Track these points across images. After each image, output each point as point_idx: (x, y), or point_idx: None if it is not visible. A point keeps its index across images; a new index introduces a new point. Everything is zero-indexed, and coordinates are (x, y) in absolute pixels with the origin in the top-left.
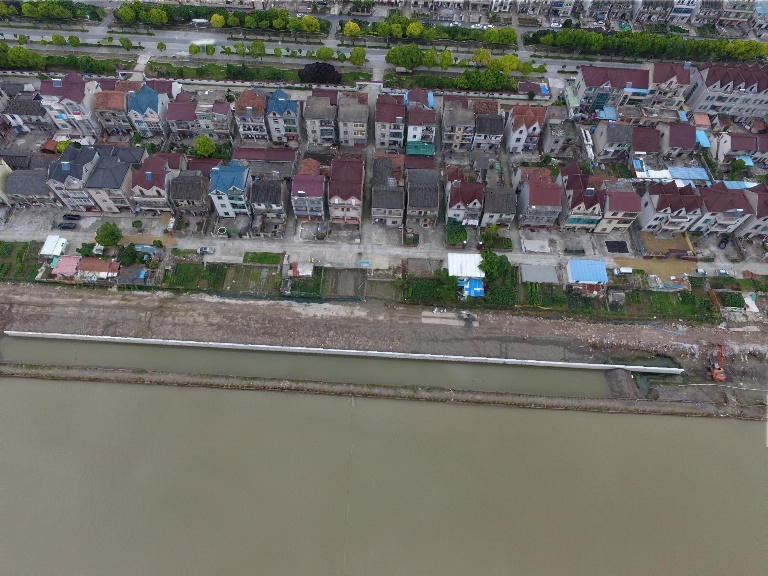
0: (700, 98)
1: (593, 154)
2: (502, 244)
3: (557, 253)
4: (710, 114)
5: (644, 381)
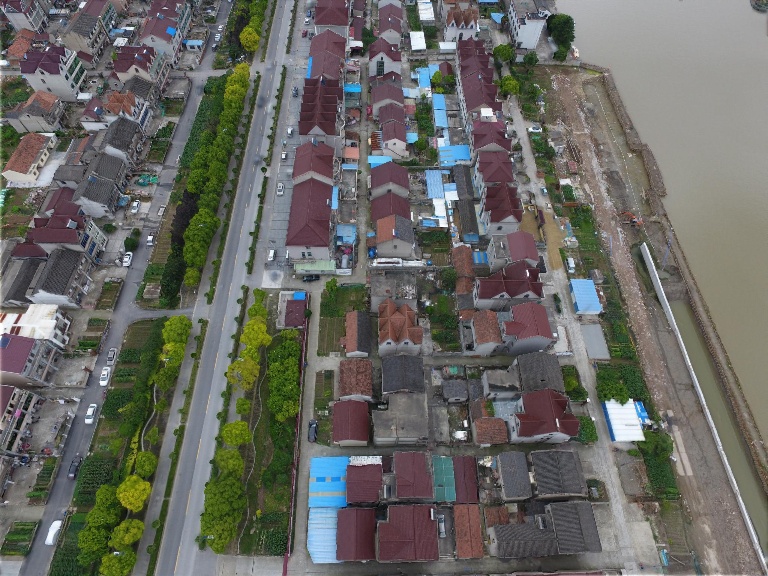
0: (336, 146)
1: (416, 261)
2: (572, 376)
3: (563, 320)
4: (345, 144)
5: (658, 273)
